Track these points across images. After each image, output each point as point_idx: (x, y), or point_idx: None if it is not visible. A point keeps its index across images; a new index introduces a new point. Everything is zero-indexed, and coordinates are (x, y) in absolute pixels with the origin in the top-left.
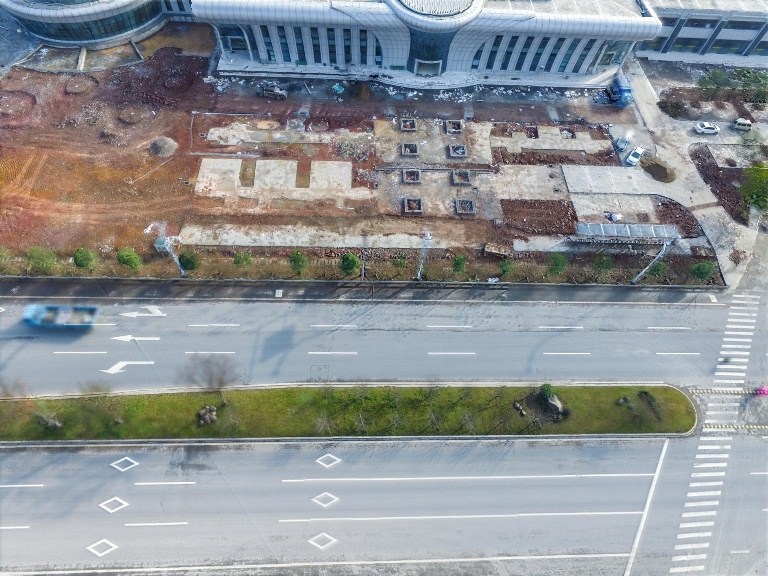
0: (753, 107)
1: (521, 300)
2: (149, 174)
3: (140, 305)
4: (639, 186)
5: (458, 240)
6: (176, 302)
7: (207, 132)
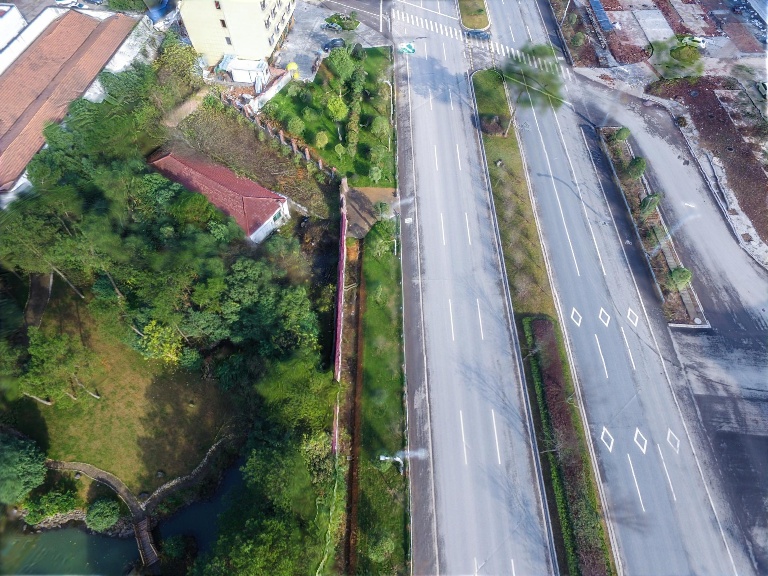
0: None
1: None
2: None
3: None
4: (658, 41)
5: None
6: None
7: None
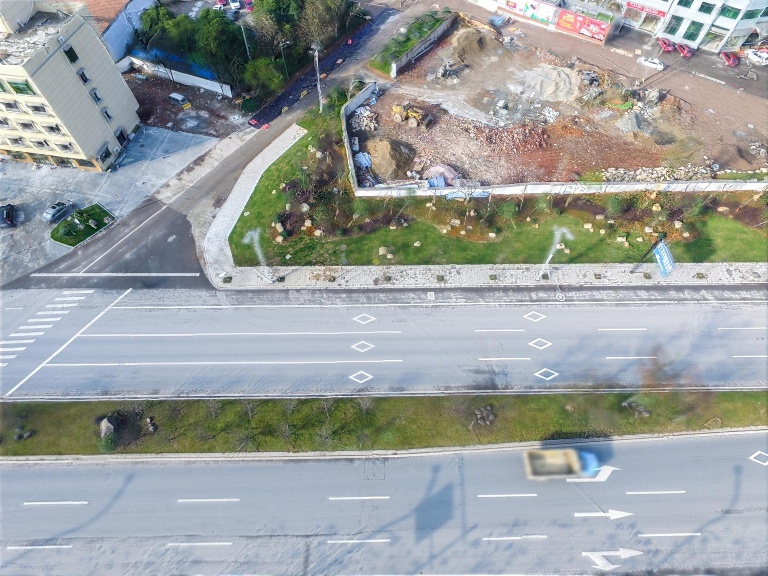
0: None
1: None
2: None
3: (624, 570)
4: None
5: None
6: None
7: None
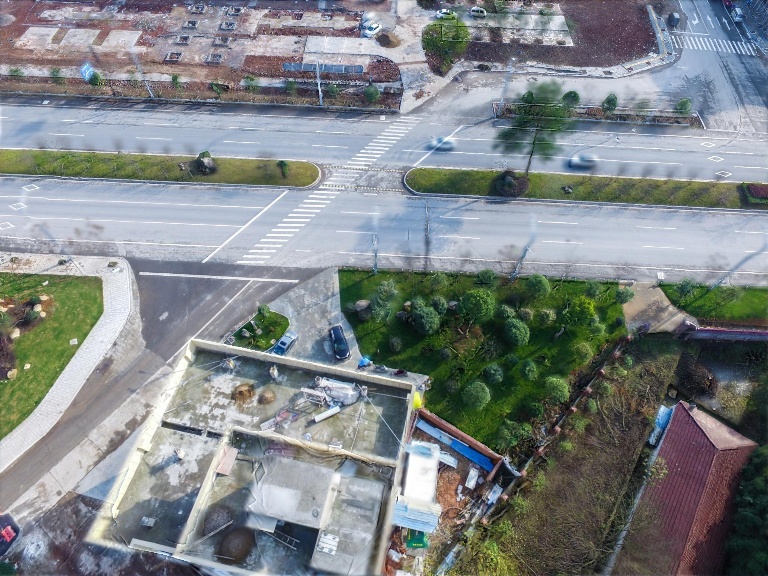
0: (502, 4)
1: (226, 112)
2: None
3: None
4: (364, 49)
5: (198, 78)
6: None
7: (42, 12)
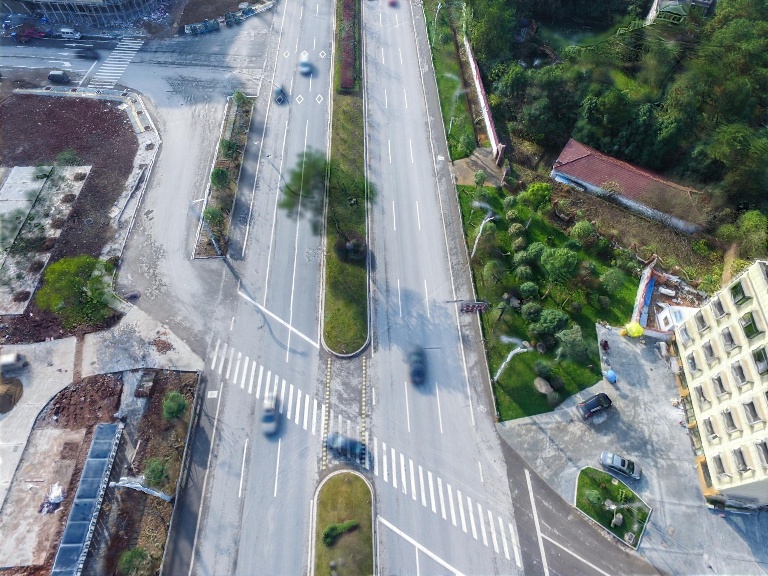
0: None
1: None
2: None
3: None
4: (12, 440)
5: None
6: None
7: None
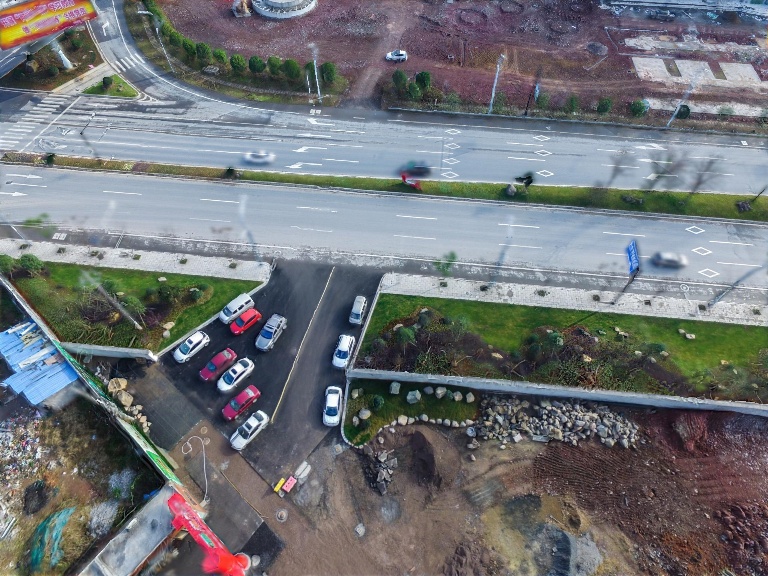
0: None
1: None
2: (597, 65)
3: (644, 143)
4: None
5: None
6: (669, 143)
7: (623, 41)
